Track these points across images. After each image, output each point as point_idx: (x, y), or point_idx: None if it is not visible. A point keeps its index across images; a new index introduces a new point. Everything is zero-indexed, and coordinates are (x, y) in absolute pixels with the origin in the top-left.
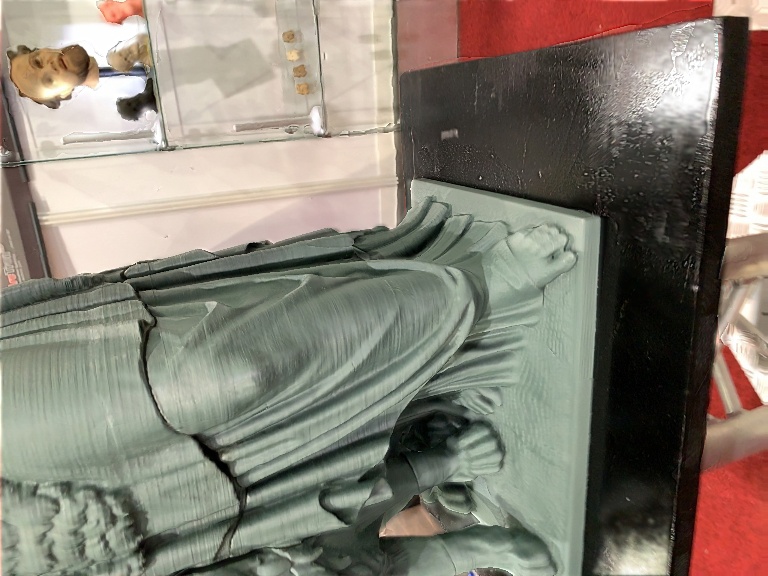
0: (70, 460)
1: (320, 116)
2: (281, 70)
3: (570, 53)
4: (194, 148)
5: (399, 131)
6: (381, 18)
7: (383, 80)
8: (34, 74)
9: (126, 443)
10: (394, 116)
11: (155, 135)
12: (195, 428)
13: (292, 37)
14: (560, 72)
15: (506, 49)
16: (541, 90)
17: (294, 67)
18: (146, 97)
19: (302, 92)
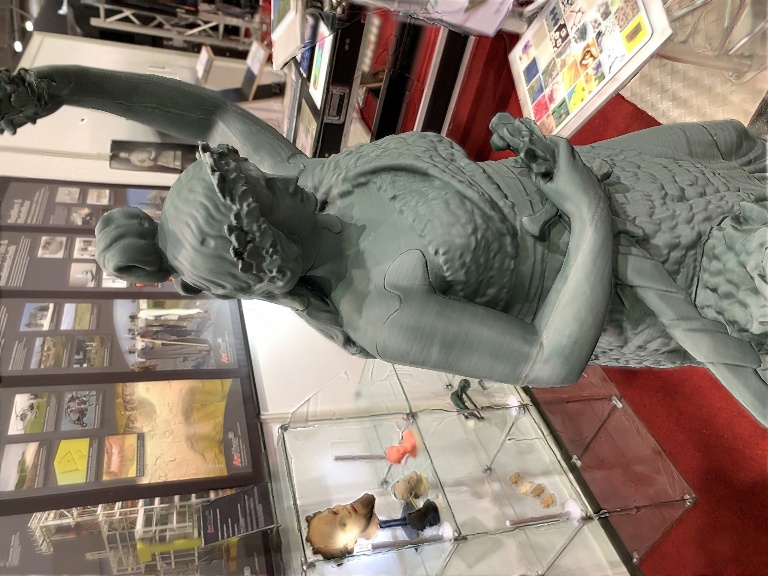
0: (669, 142)
1: (576, 501)
2: (507, 538)
3: (761, 109)
4: (483, 534)
5: (638, 575)
6: (570, 490)
7: (597, 535)
8: (333, 518)
9: (693, 136)
10: (625, 566)
11: (444, 535)
12: (723, 140)
13: (518, 476)
14: (763, 121)
15: (698, 401)
16: (760, 137)
17: (531, 491)
18: (431, 505)
19: (547, 503)
